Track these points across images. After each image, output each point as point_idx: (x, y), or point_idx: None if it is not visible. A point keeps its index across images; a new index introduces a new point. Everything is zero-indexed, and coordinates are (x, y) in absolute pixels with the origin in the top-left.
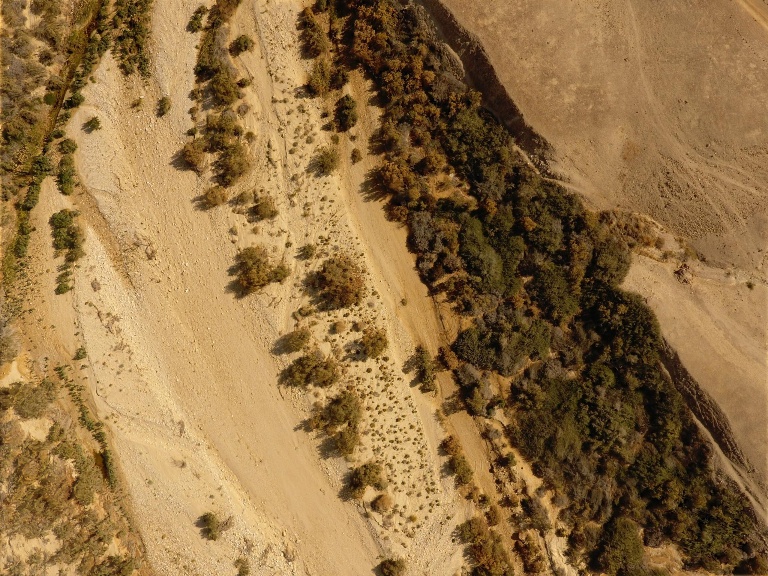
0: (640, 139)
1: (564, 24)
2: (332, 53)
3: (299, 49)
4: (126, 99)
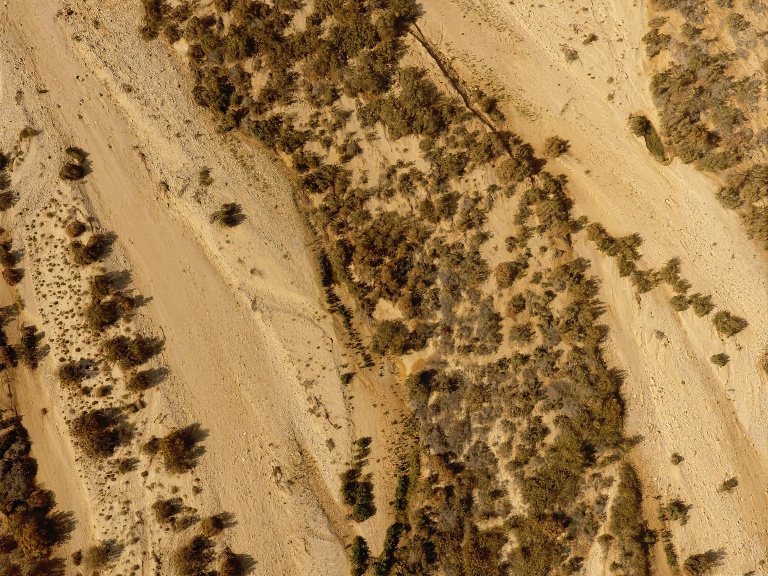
0: None
1: None
2: None
3: None
4: None
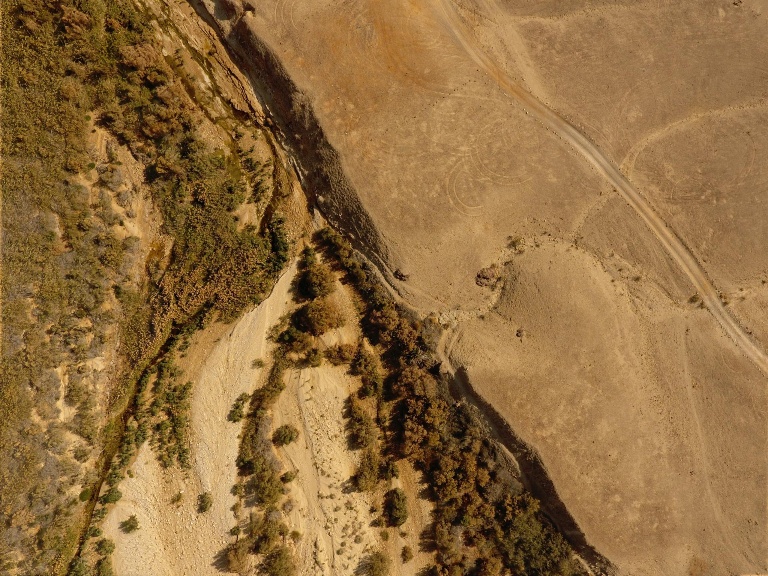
0: (707, 556)
1: (626, 434)
2: (380, 440)
3: (346, 440)
4: (165, 494)
